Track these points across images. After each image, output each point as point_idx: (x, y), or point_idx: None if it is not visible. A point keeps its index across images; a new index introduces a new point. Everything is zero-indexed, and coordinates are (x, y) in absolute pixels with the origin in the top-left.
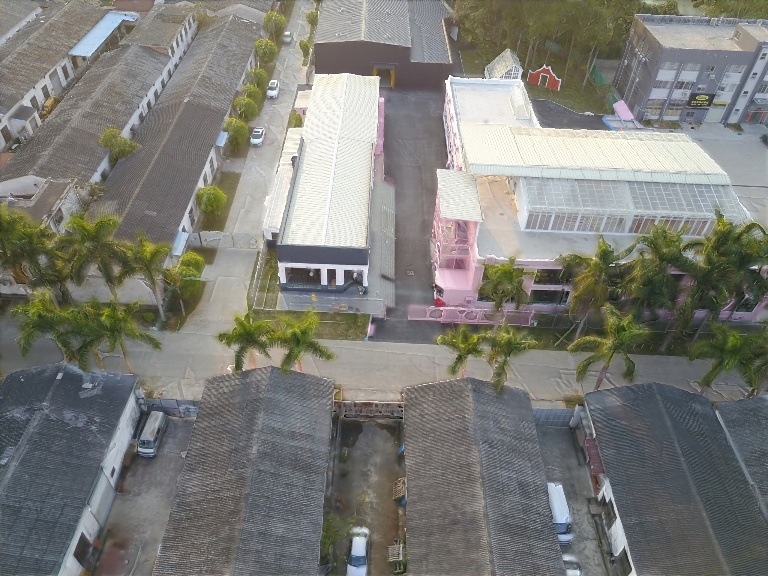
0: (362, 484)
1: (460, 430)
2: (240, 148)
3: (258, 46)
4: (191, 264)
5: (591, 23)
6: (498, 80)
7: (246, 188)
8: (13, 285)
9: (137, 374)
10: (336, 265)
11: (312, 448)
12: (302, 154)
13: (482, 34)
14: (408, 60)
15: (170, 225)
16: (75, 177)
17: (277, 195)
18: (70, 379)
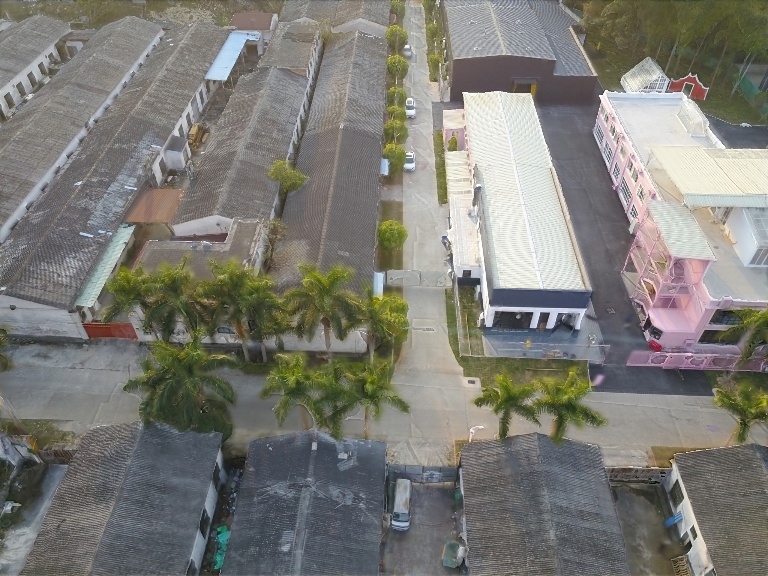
0: (637, 562)
1: (764, 508)
2: (397, 174)
3: (391, 63)
4: (399, 310)
5: (755, 29)
6: (658, 93)
7: (412, 218)
8: (215, 334)
9: (361, 432)
10: (551, 308)
11: (605, 530)
12: (481, 183)
13: (623, 42)
14: (551, 73)
15: (365, 266)
16: (256, 215)
17: (459, 228)
18: (325, 449)
